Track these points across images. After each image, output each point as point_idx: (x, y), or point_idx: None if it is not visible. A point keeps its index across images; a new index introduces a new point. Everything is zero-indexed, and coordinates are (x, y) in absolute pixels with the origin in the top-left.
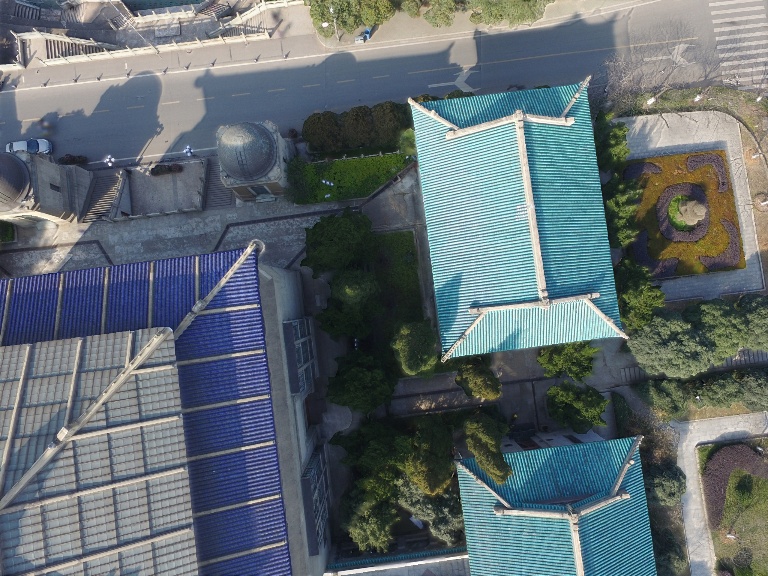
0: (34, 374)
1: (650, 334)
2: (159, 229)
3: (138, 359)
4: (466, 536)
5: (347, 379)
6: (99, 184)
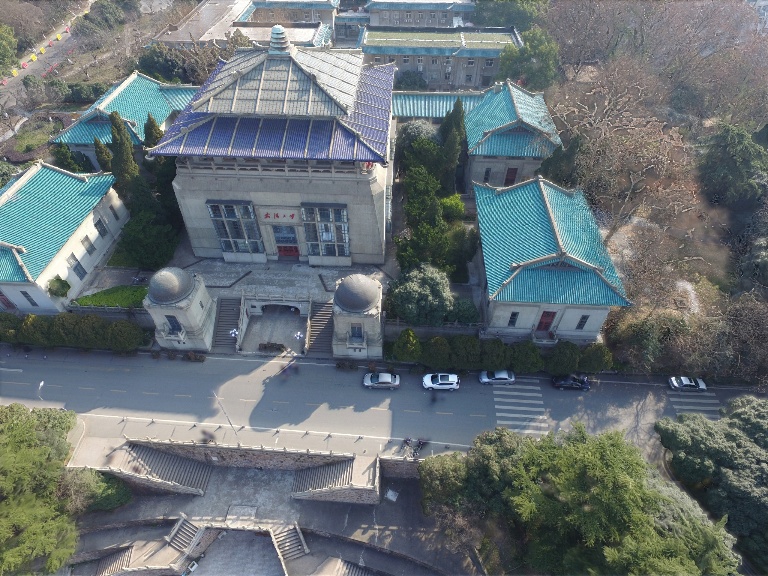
0: (254, 101)
1: (8, 181)
2: (280, 292)
3: (204, 97)
4: (159, 126)
5: (172, 166)
6: (328, 344)
